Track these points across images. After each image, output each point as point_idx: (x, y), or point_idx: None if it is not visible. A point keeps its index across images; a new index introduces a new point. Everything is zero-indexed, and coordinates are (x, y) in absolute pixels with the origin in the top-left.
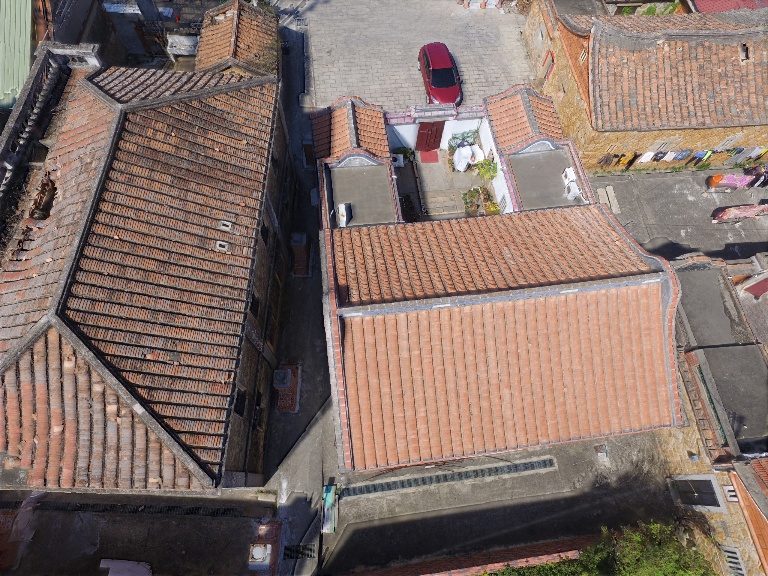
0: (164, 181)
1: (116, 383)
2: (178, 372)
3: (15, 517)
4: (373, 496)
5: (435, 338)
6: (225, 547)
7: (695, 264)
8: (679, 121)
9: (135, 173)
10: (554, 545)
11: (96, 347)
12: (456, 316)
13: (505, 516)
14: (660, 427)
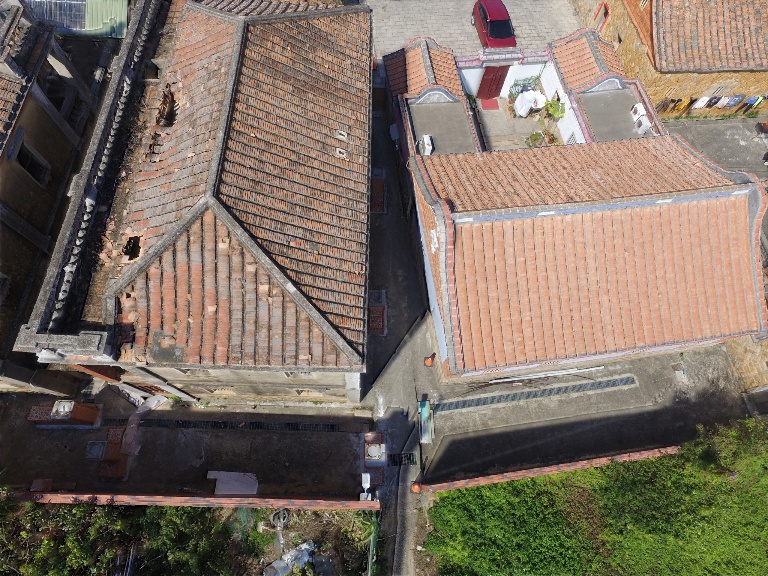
0: (286, 90)
1: (269, 263)
2: (318, 260)
3: (124, 430)
4: (465, 411)
5: (539, 245)
6: (326, 459)
7: (767, 188)
8: (738, 63)
9: (261, 80)
10: (646, 449)
11: (248, 230)
12: (558, 224)
13: (593, 428)
14: (748, 332)
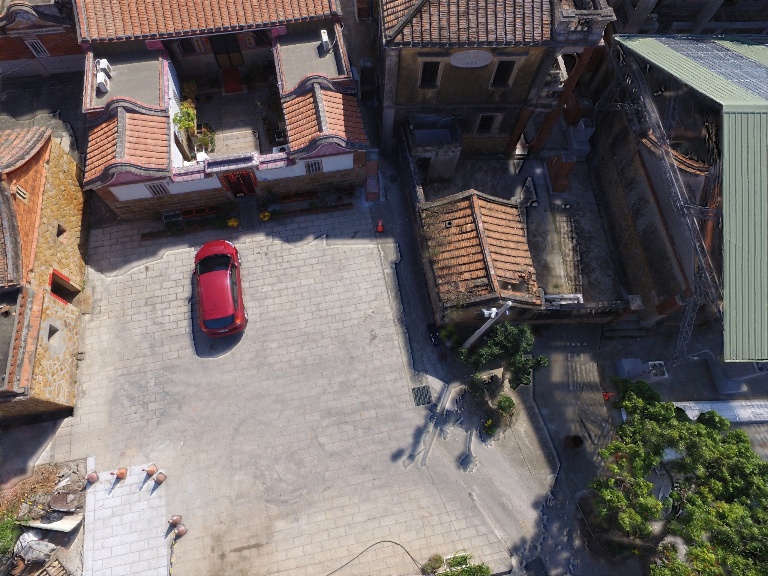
0: None
1: None
2: None
3: None
4: None
5: None
6: None
7: None
8: None
9: None
10: None
11: None
12: None
13: None
14: None
